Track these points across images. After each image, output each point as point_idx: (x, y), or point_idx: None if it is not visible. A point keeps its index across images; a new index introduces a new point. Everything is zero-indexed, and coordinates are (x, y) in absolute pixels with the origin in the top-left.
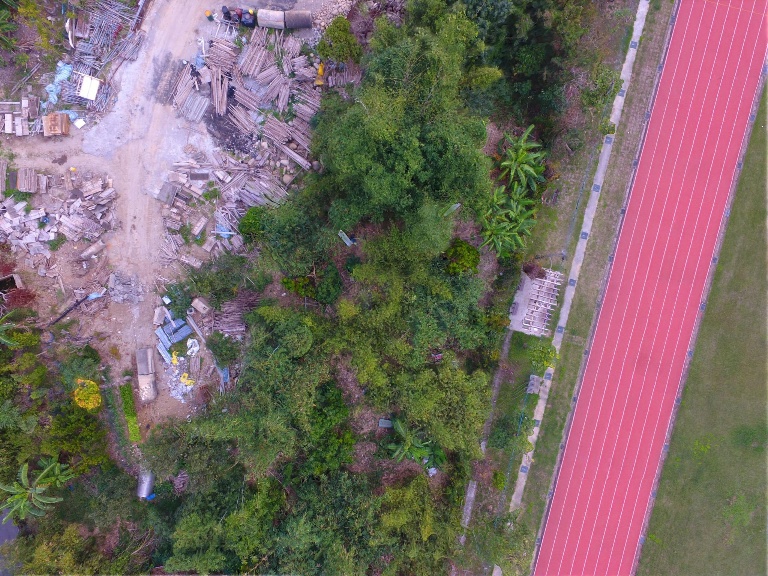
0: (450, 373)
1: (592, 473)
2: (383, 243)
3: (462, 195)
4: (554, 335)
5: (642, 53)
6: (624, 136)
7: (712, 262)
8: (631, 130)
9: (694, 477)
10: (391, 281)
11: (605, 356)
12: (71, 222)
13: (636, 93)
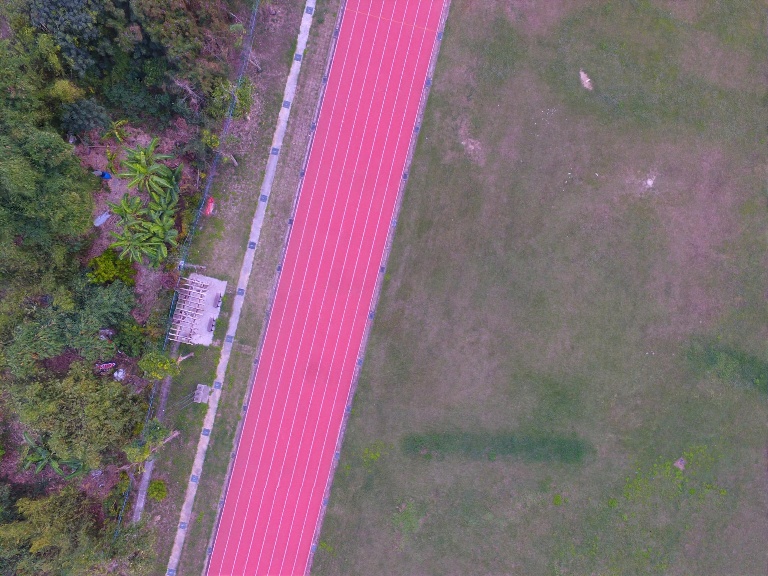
0: (69, 384)
1: (263, 482)
2: None
3: (38, 207)
4: (223, 344)
5: (306, 66)
6: (290, 147)
7: (380, 271)
8: (297, 141)
9: (364, 485)
10: (5, 292)
11: (274, 365)
12: None
13: (301, 105)
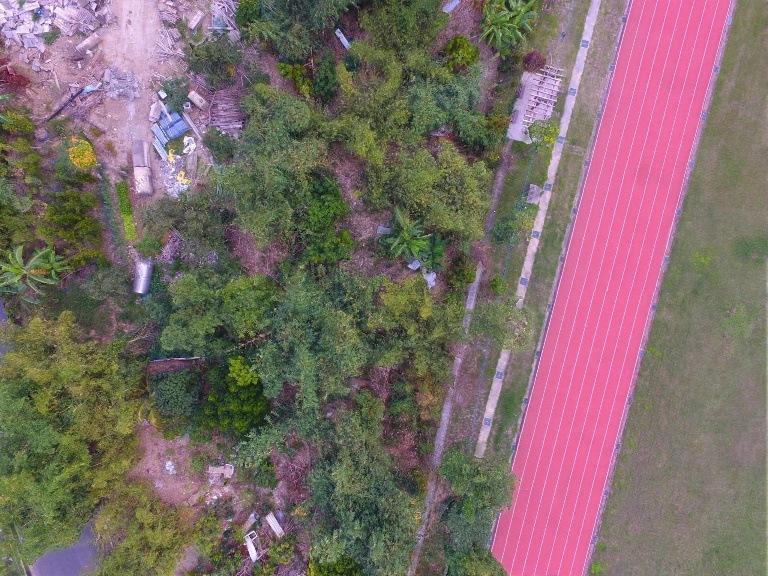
0: (449, 154)
1: (592, 285)
2: (382, 13)
3: None
4: (554, 145)
5: None
6: None
7: (714, 71)
8: None
9: (694, 289)
10: (390, 58)
11: (605, 167)
12: (66, 11)
13: None
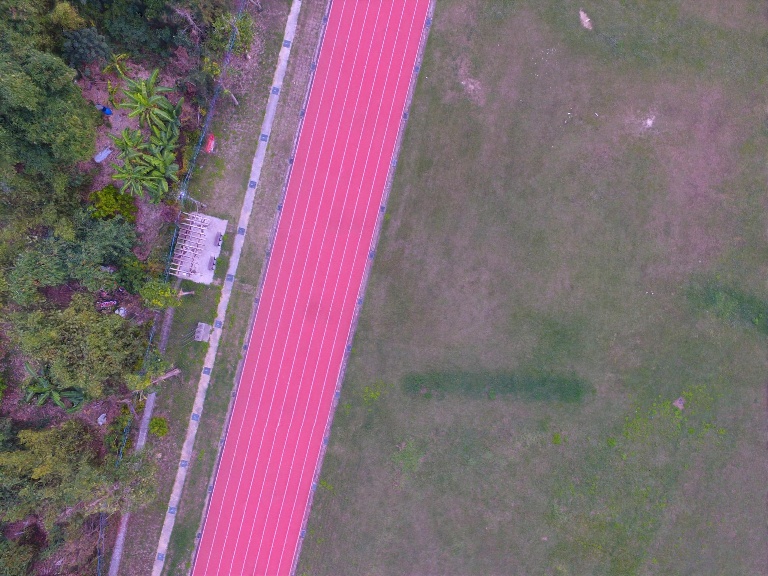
0: (70, 313)
1: (263, 420)
2: None
3: (39, 129)
4: (224, 283)
5: (307, 5)
6: (290, 86)
7: (380, 211)
8: (297, 81)
9: (364, 424)
10: (7, 221)
11: (275, 304)
12: None
13: (301, 44)
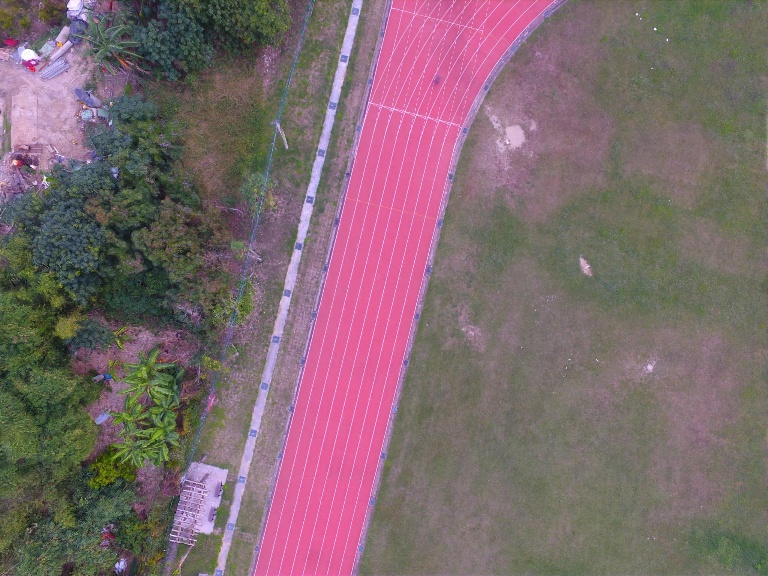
0: None
1: None
2: None
3: (40, 448)
4: (224, 532)
5: (307, 254)
6: (291, 335)
7: (381, 458)
8: (298, 329)
9: None
10: (7, 512)
11: (276, 552)
12: None
13: (302, 293)
